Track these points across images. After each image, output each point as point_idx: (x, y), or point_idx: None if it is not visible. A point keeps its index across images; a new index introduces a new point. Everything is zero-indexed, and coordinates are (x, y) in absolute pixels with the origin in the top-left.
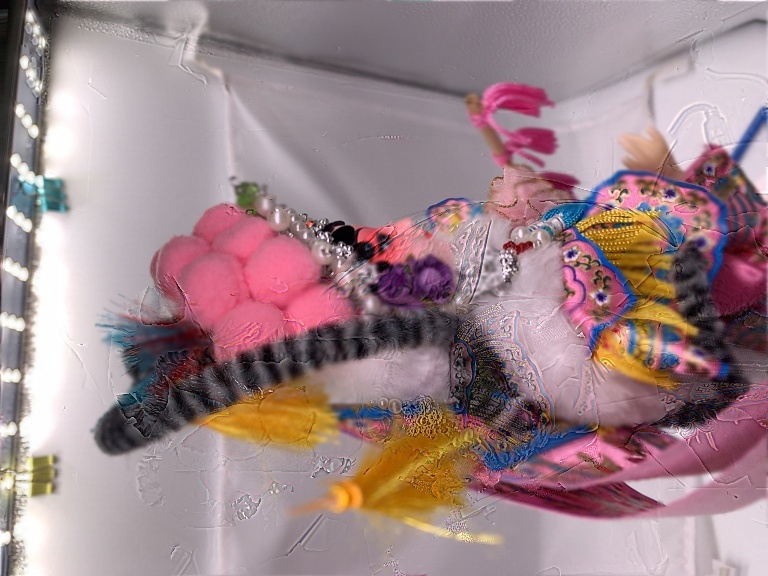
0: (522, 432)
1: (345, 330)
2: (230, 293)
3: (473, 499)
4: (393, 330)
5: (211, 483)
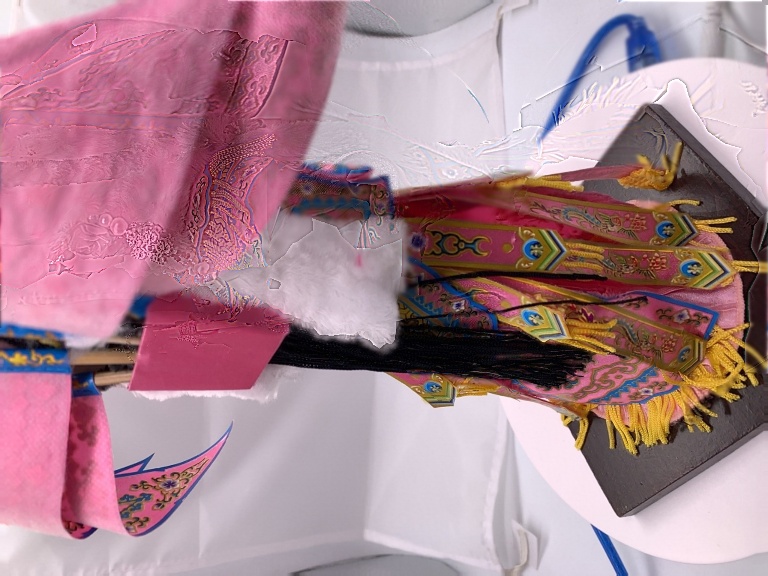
0: None
1: (64, 130)
2: None
3: (209, 319)
4: (144, 133)
5: None
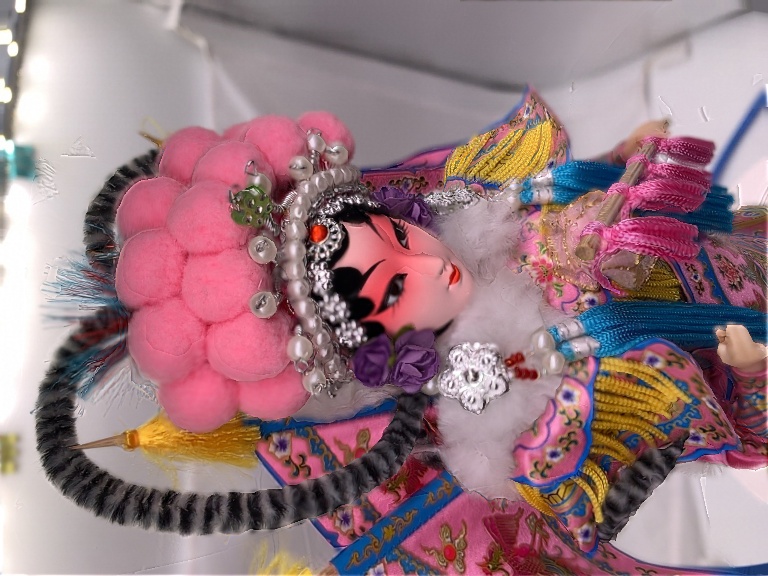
0: (533, 132)
1: None
2: (144, 132)
3: None
4: None
5: (179, 199)
